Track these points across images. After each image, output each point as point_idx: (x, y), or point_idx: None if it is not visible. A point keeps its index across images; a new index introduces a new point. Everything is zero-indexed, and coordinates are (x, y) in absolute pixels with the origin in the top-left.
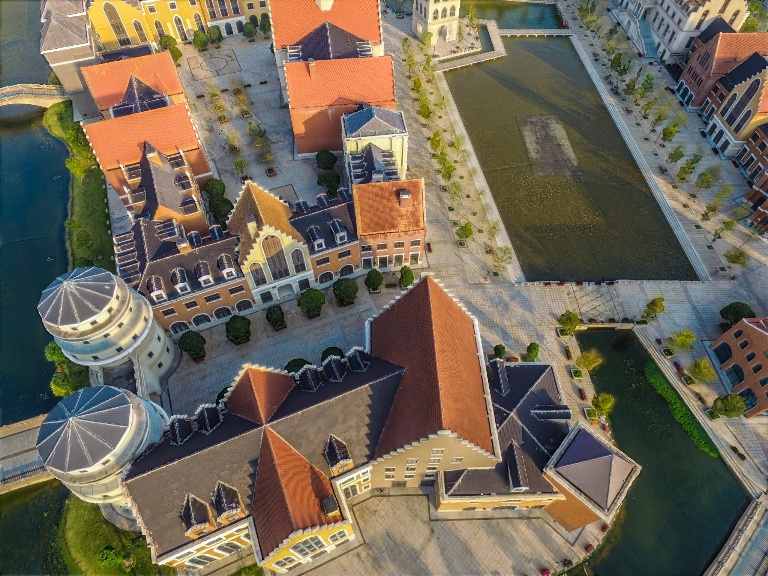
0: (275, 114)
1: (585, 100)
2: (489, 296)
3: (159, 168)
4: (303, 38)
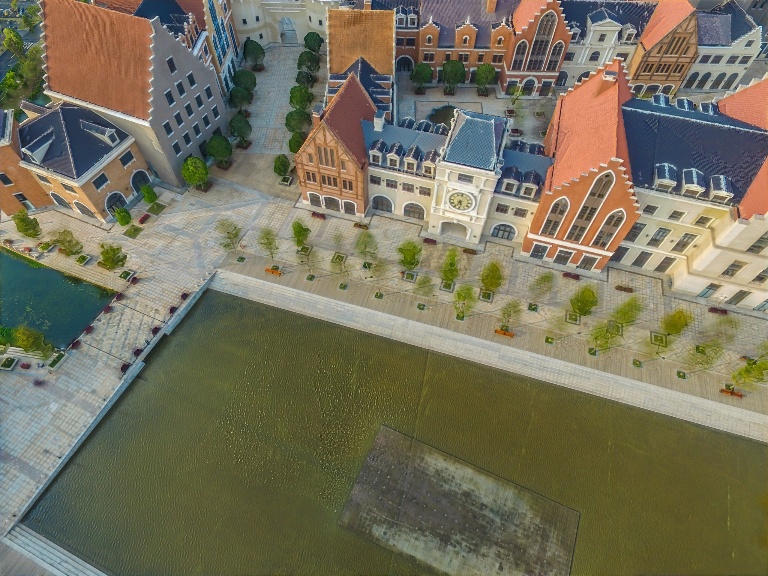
0: None
1: None
2: (221, 239)
3: (482, 7)
4: (738, 120)
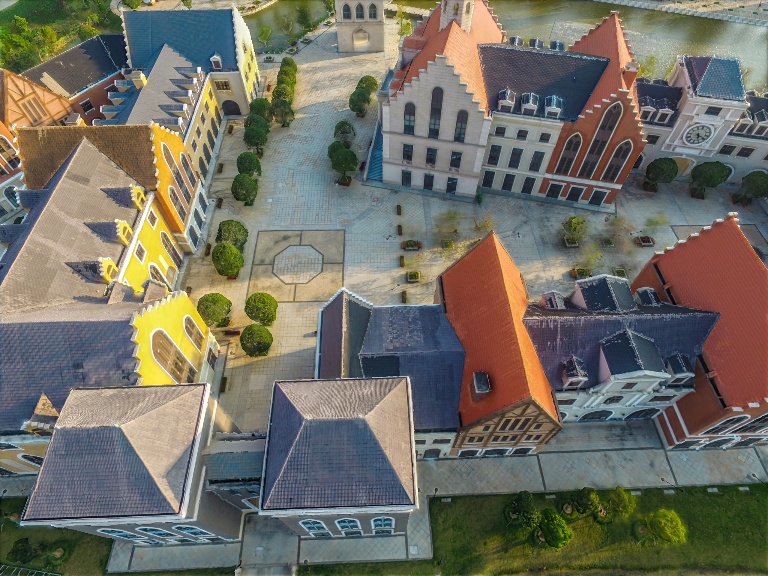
0: (494, 213)
1: (536, 0)
2: None
3: None
4: (487, 83)
